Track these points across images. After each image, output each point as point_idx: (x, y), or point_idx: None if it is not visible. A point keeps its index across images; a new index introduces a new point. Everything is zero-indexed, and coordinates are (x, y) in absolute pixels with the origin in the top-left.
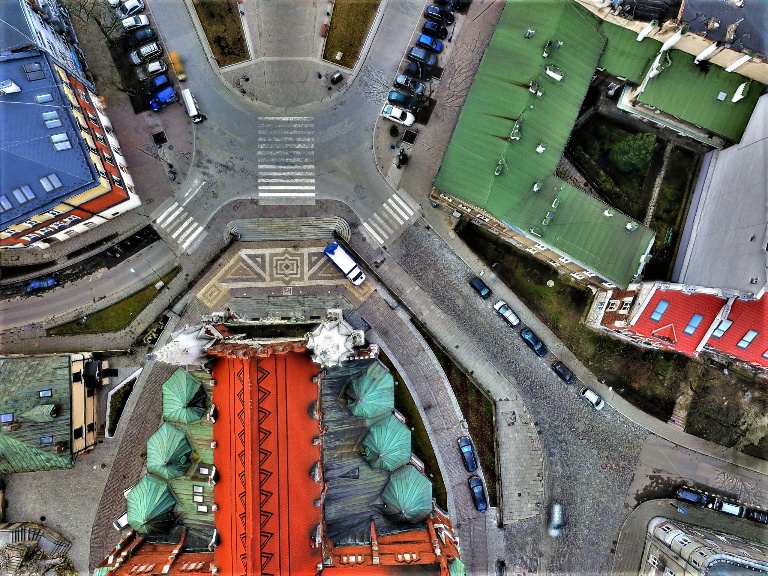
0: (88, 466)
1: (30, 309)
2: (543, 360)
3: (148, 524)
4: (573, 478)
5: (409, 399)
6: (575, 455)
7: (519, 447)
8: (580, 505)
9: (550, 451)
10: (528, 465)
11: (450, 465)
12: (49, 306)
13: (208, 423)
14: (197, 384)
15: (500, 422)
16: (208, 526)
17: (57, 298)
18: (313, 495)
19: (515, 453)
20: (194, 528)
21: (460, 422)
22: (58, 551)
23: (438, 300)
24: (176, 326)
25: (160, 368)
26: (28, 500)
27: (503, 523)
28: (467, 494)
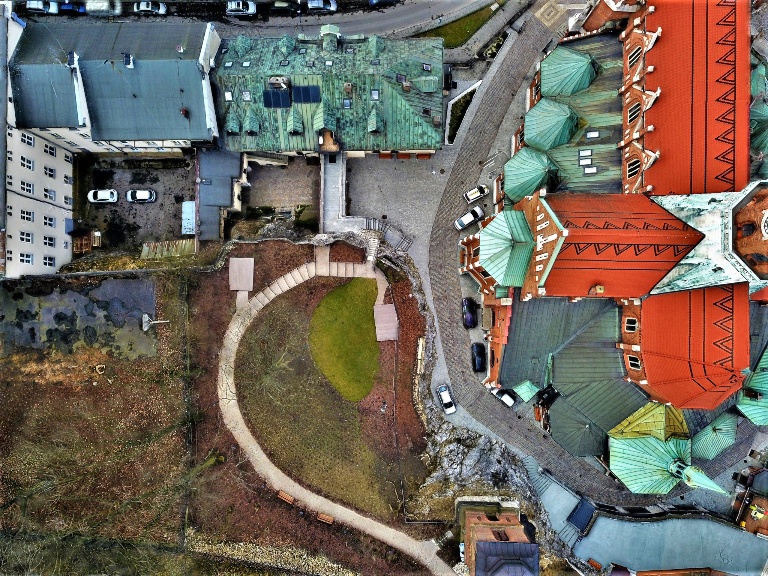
0: (427, 171)
1: (372, 23)
2: None
3: (548, 173)
4: None
5: None
6: None
7: None
8: None
9: None
10: None
11: None
12: (390, 21)
13: (598, 89)
14: (585, 54)
15: None
16: (597, 186)
17: (397, 14)
18: None
19: None
20: (580, 190)
21: None
22: (401, 246)
23: (766, 34)
24: (514, 43)
25: (498, 82)
26: (371, 199)
27: None
28: None
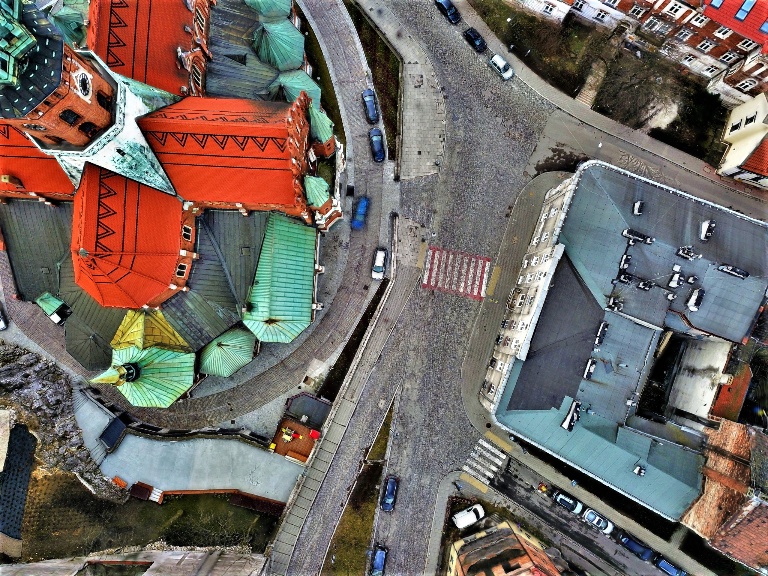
0: None
1: None
2: (456, 28)
3: None
4: (475, 143)
5: (317, 50)
6: (479, 121)
7: (423, 108)
8: (479, 169)
9: (454, 115)
10: (431, 126)
11: (352, 117)
12: None
13: None
14: None
15: (407, 83)
16: None
17: None
18: (184, 20)
19: (419, 114)
20: None
21: (366, 75)
22: None
23: None
24: None
25: None
26: None
27: (400, 177)
28: (367, 146)
